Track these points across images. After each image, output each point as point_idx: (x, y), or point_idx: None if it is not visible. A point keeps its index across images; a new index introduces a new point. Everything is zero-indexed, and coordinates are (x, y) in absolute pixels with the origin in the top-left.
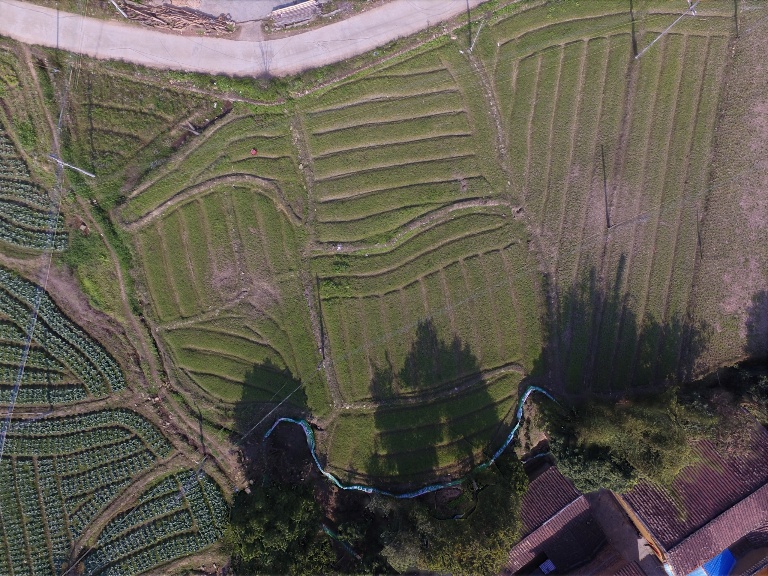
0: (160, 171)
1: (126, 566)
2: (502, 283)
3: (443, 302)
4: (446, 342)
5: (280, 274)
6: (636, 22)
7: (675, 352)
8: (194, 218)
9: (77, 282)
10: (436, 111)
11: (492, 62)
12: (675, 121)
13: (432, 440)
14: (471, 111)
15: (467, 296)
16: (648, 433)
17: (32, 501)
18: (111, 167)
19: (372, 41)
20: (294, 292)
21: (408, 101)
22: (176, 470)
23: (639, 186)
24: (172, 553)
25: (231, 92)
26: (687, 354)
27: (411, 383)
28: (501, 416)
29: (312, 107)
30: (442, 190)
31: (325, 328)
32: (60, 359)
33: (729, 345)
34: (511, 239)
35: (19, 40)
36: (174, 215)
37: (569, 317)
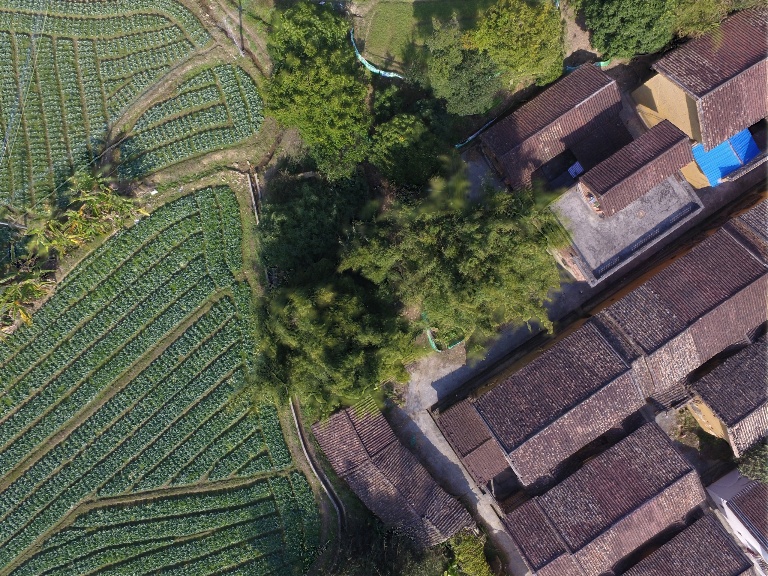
0: None
1: (162, 153)
2: None
3: None
4: None
5: None
6: None
7: None
8: None
9: None
10: None
11: None
12: None
13: None
14: None
15: None
16: None
17: (71, 78)
18: None
19: None
20: None
21: None
22: (214, 63)
23: None
24: (207, 143)
25: None
26: None
27: None
28: None
29: None
30: None
31: None
32: None
33: None
34: None
35: None
36: None
37: None
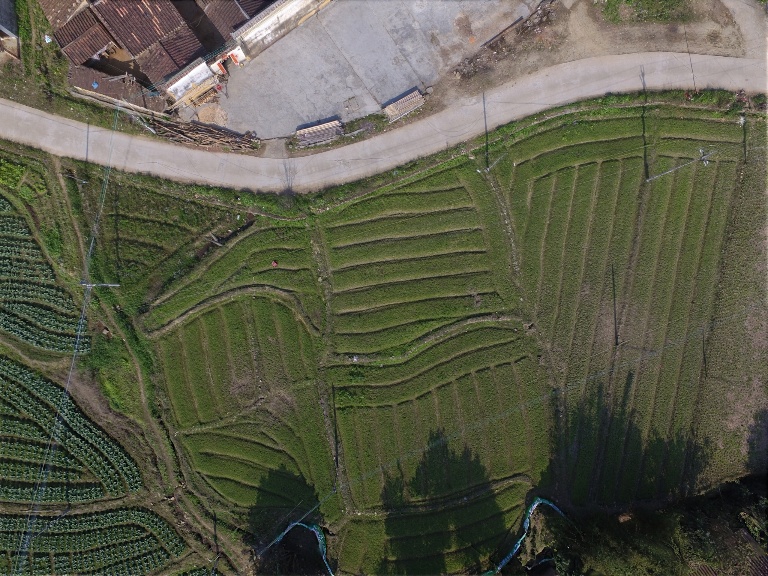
0: (183, 281)
1: None
2: (512, 396)
3: (455, 413)
4: (457, 452)
5: (297, 382)
6: (648, 146)
7: (679, 467)
8: (214, 326)
9: (98, 385)
10: (452, 228)
11: (508, 182)
12: (684, 242)
13: (441, 547)
14: (486, 229)
15: (478, 407)
16: (653, 570)
17: None
18: (135, 277)
19: (392, 160)
20: (310, 400)
21: (426, 218)
22: (189, 568)
23: (647, 305)
24: None
25: (254, 207)
26: (690, 470)
27: (422, 492)
28: (508, 525)
29: (332, 222)
30: (456, 305)
31: (339, 436)
32: (79, 458)
33: (731, 461)
34: (522, 353)
35: (49, 152)
36: (195, 323)
37: (577, 431)
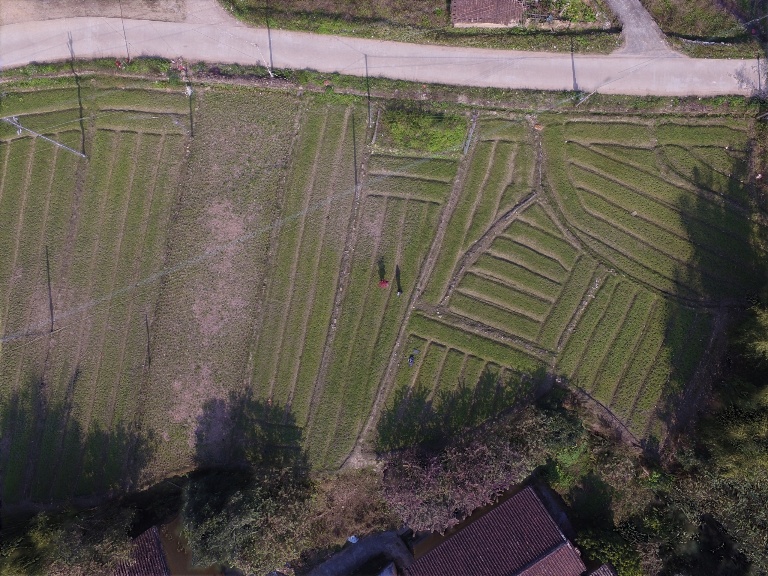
0: None
1: None
2: None
3: None
4: None
5: None
6: (85, 119)
7: (119, 461)
8: None
9: None
10: None
11: None
12: (126, 222)
13: None
14: None
15: None
16: None
17: None
18: None
19: None
20: None
21: None
22: None
23: (86, 289)
24: None
25: None
26: (132, 464)
27: None
28: None
29: None
30: None
31: None
32: None
33: (177, 454)
34: None
35: None
36: None
37: (8, 424)
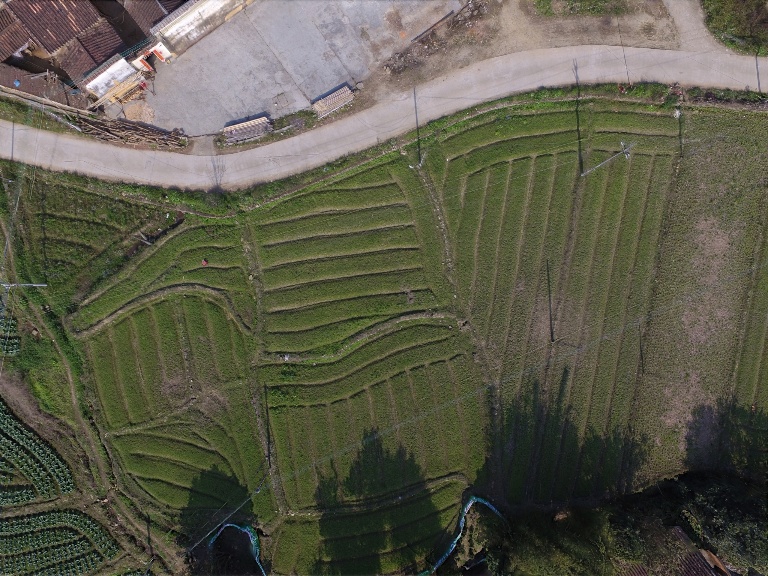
0: (111, 280)
1: None
2: (447, 394)
3: (389, 412)
4: (391, 451)
5: (228, 382)
6: (582, 140)
7: (616, 465)
8: (145, 326)
9: (28, 386)
10: (385, 224)
11: (441, 177)
12: (619, 237)
13: (376, 548)
14: (419, 225)
15: (413, 406)
16: (575, 569)
17: None
18: (63, 276)
19: (322, 157)
20: (242, 399)
21: (357, 215)
22: (124, 570)
23: (583, 301)
24: None
25: (183, 205)
26: (628, 467)
27: (356, 492)
28: (444, 524)
29: (263, 219)
30: (389, 303)
31: (272, 436)
32: (10, 460)
33: (669, 458)
34: (457, 351)
35: None
36: (125, 323)
37: (512, 429)
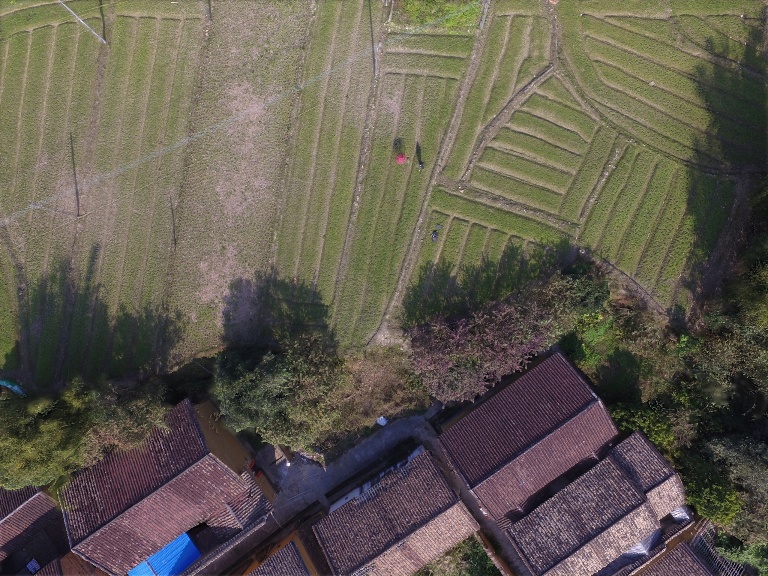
0: None
1: None
2: None
3: None
4: None
5: None
6: (105, 6)
7: (148, 343)
8: None
9: None
10: None
11: None
12: (148, 106)
13: None
14: None
15: None
16: None
17: None
18: None
19: None
20: None
21: None
22: None
23: (111, 174)
24: None
25: None
26: (161, 345)
27: None
28: None
29: None
30: None
31: None
32: None
33: (206, 335)
34: None
35: None
36: None
37: (37, 309)
